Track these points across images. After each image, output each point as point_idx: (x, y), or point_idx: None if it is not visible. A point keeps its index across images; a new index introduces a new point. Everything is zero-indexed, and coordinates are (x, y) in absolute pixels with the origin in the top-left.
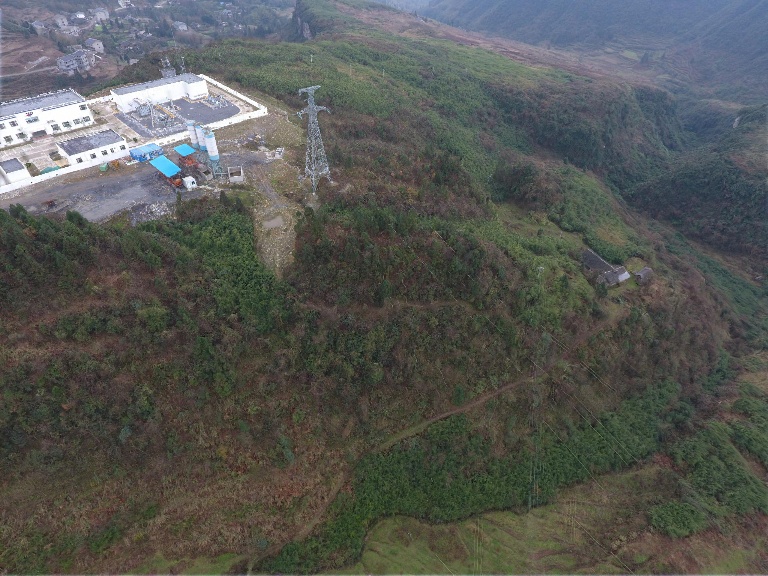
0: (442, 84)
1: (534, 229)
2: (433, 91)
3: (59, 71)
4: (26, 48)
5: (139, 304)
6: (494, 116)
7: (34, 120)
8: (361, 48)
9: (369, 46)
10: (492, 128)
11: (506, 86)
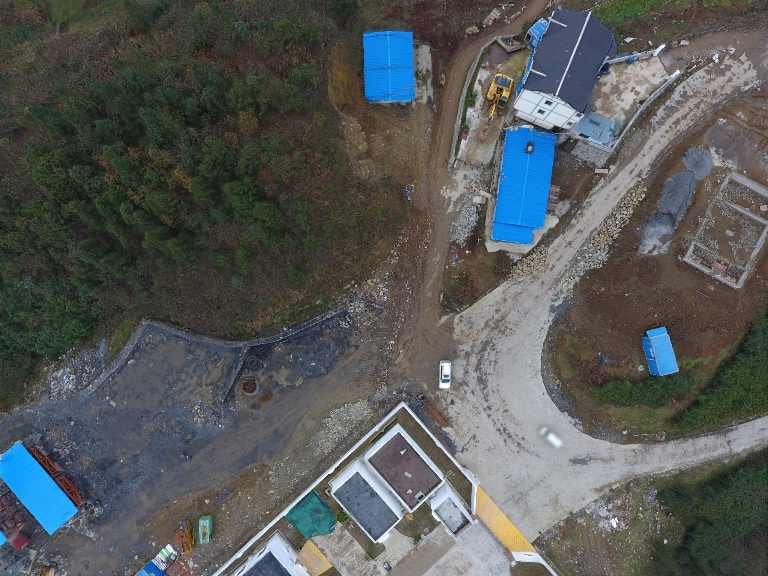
0: None
1: None
2: None
3: None
4: None
5: None
6: None
7: None
8: None
9: None
10: None
11: None
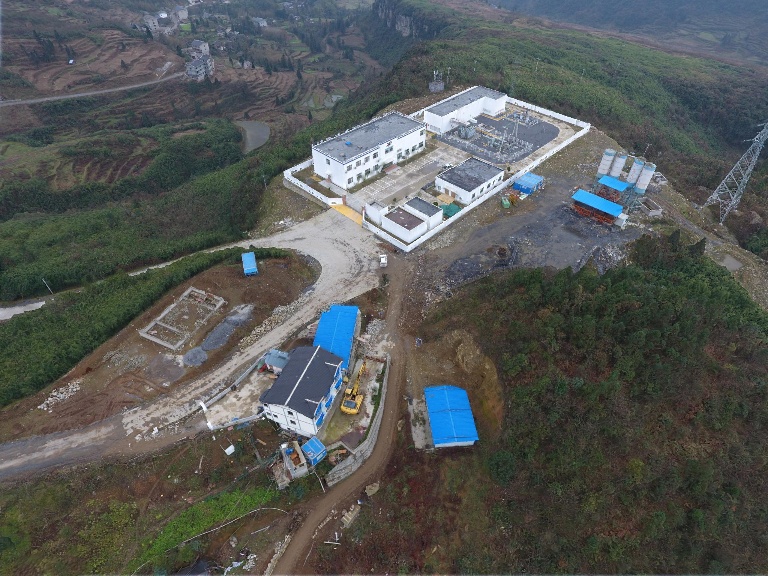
0: (631, 82)
1: None
2: (624, 90)
3: (188, 77)
4: (149, 54)
5: (763, 381)
6: (681, 114)
7: (389, 150)
8: (536, 45)
9: (540, 42)
10: (684, 127)
11: (685, 81)
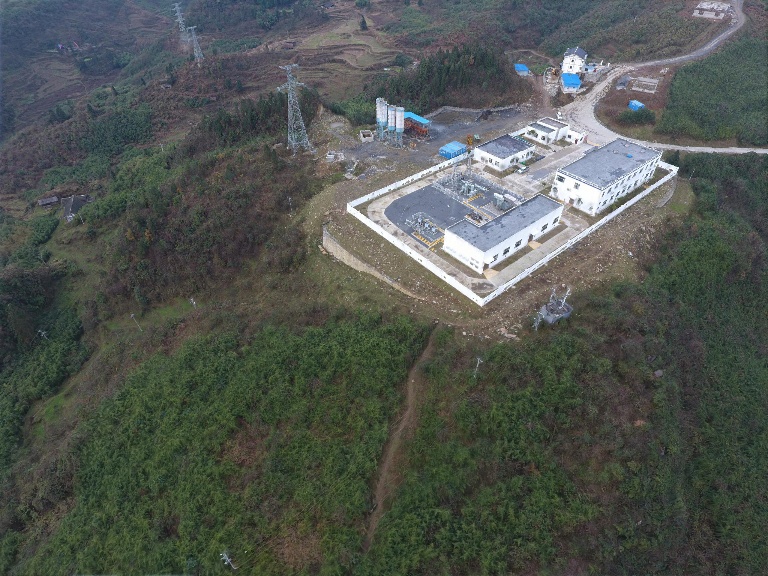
0: None
1: (81, 255)
2: None
3: None
4: None
5: None
6: None
7: None
8: None
9: None
10: None
11: None
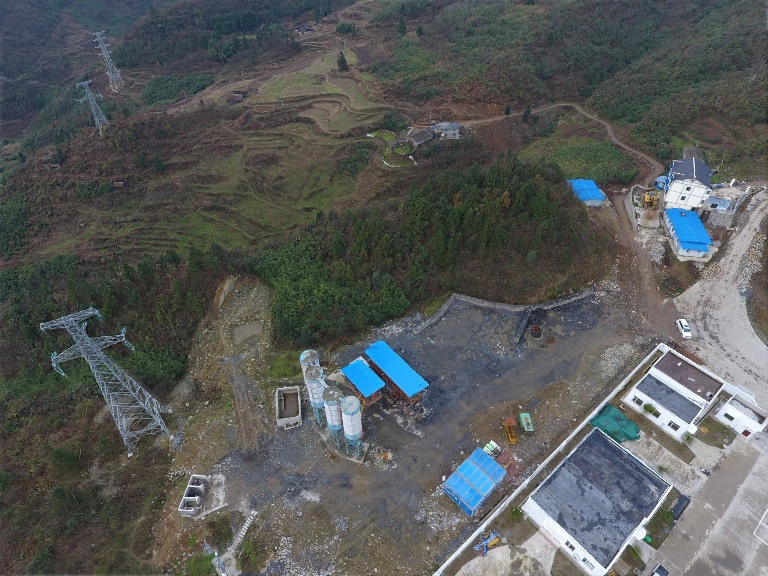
0: None
1: None
2: None
3: None
4: None
5: None
6: None
7: None
8: None
9: None
10: None
11: None
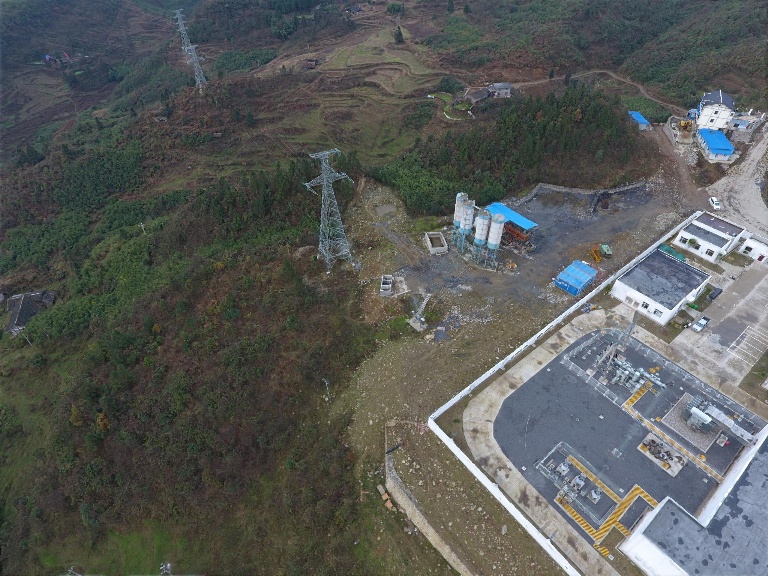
0: None
1: (23, 397)
2: None
3: None
4: None
5: None
6: None
7: None
8: None
9: None
10: None
11: None
